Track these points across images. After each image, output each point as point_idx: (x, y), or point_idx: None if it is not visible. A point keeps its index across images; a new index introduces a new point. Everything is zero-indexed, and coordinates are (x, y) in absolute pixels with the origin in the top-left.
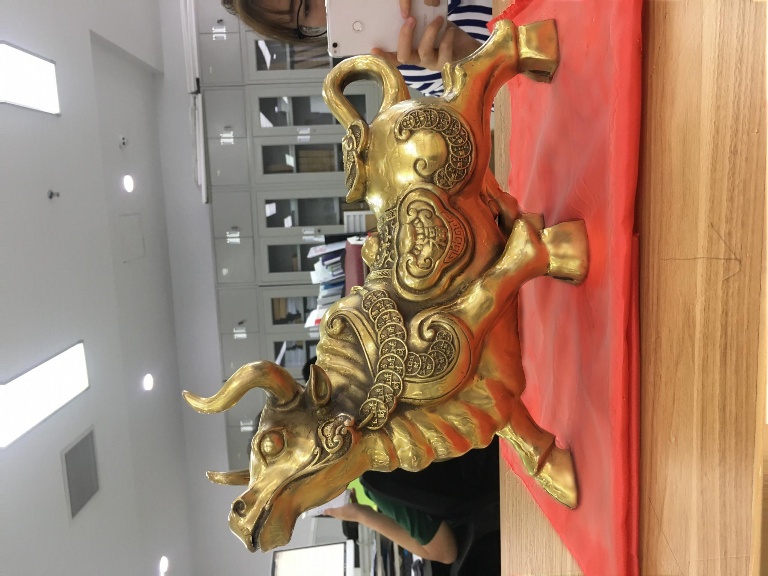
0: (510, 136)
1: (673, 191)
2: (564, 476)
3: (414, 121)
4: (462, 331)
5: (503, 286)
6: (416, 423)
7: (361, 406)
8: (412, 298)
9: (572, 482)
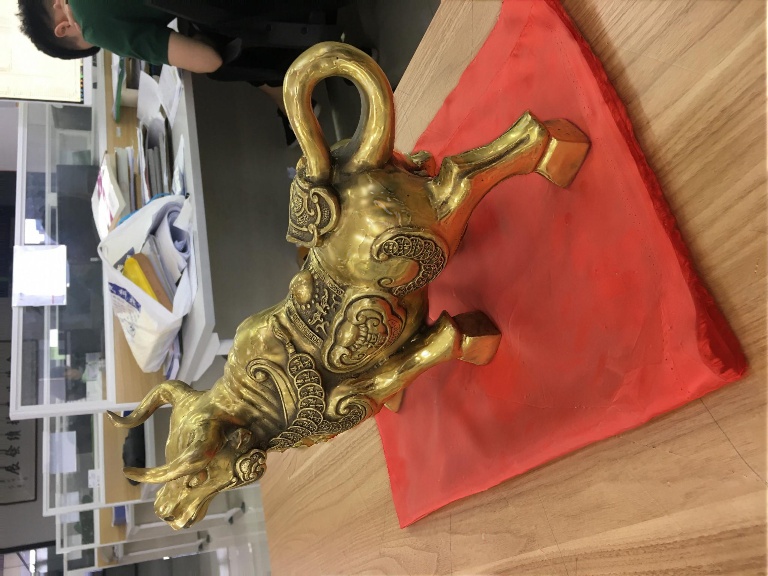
0: (471, 48)
1: (572, 499)
2: (394, 401)
3: (397, 249)
4: (371, 408)
5: (415, 377)
6: (310, 438)
7: (272, 439)
8: (336, 371)
9: (398, 405)
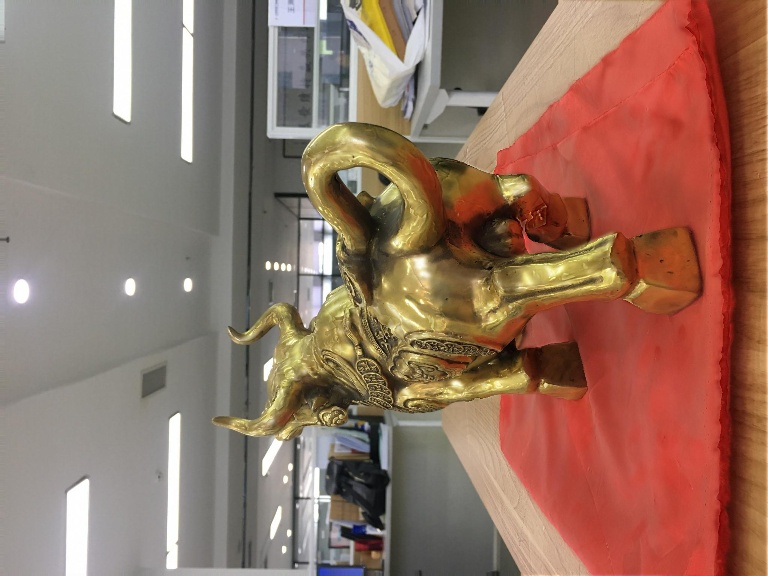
0: (641, 6)
1: None
2: None
3: None
4: None
5: None
6: None
7: None
8: None
9: None
